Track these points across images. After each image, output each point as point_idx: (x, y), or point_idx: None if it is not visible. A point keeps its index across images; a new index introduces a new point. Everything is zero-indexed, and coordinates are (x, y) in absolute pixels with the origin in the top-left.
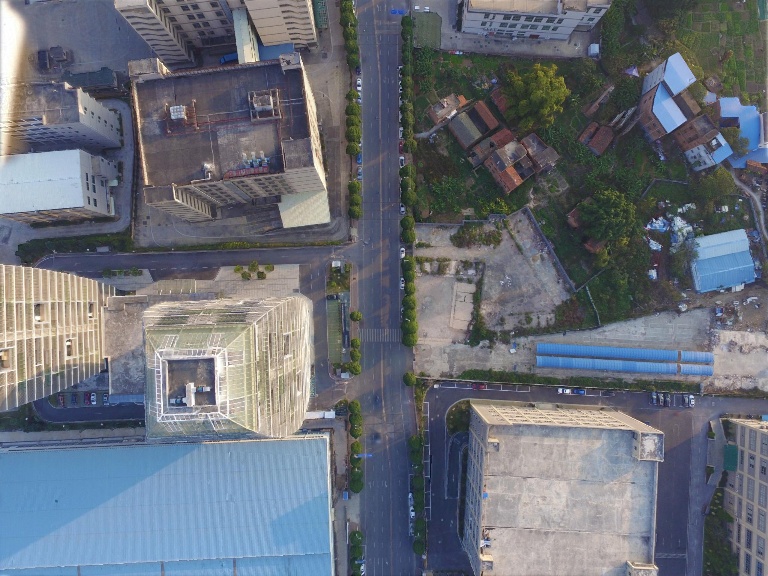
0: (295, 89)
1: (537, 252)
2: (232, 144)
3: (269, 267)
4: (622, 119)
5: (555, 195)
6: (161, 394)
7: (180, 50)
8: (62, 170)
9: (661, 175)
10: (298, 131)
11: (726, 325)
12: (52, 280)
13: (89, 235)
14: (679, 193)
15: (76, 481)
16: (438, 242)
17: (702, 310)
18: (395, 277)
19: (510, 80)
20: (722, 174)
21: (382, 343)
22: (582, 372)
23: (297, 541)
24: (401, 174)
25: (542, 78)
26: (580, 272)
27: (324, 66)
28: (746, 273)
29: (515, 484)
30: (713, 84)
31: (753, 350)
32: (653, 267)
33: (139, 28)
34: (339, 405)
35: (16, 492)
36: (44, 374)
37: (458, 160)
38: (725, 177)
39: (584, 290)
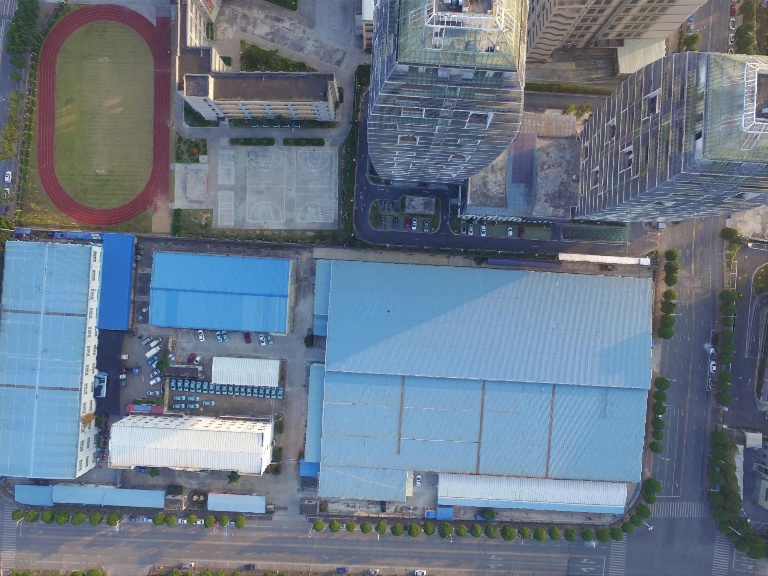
0: None
1: None
2: None
3: None
4: None
5: None
6: (755, 103)
7: None
8: None
9: None
10: None
11: None
12: None
13: None
14: None
15: (408, 294)
16: None
17: None
18: None
19: None
20: None
21: None
22: None
23: (619, 373)
24: (742, 30)
25: None
26: None
27: None
28: None
29: None
30: None
31: None
32: None
33: None
34: (650, 255)
35: (349, 299)
36: None
37: None
38: None
39: None
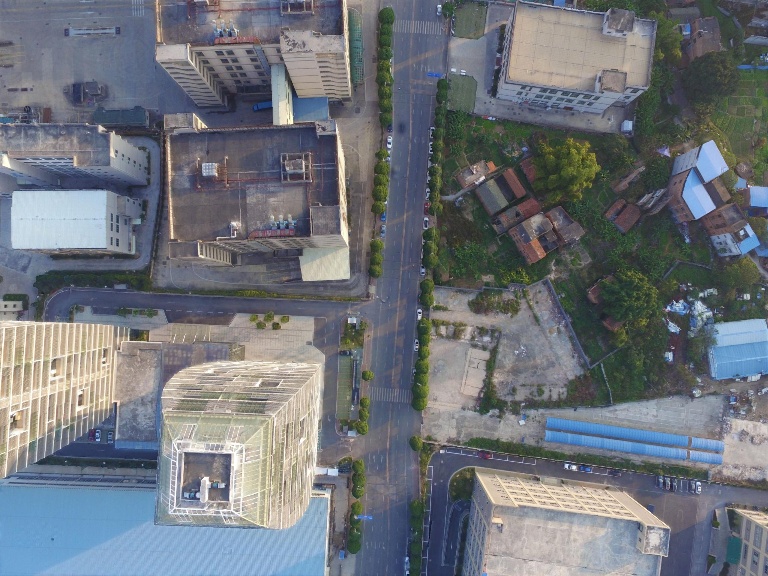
0: (328, 154)
1: (554, 324)
2: (260, 204)
3: (285, 319)
4: (650, 199)
5: (577, 268)
6: (175, 487)
7: (215, 96)
8: (88, 210)
9: (685, 258)
10: (327, 196)
11: (739, 414)
12: (71, 333)
13: (108, 271)
14: (702, 277)
15: (74, 520)
16: (456, 306)
17: (716, 397)
18: (410, 338)
19: (541, 151)
20: (747, 265)
21: (391, 403)
22: (590, 449)
23: None
24: (425, 237)
25: (574, 156)
26: (596, 348)
27: (356, 121)
28: (763, 364)
29: (515, 566)
30: (744, 170)
31: (764, 441)
32: (670, 350)
33: (177, 77)
34: (343, 462)
35: (13, 526)
36: (55, 430)
37: (482, 226)
38: (750, 268)
39: (599, 367)
